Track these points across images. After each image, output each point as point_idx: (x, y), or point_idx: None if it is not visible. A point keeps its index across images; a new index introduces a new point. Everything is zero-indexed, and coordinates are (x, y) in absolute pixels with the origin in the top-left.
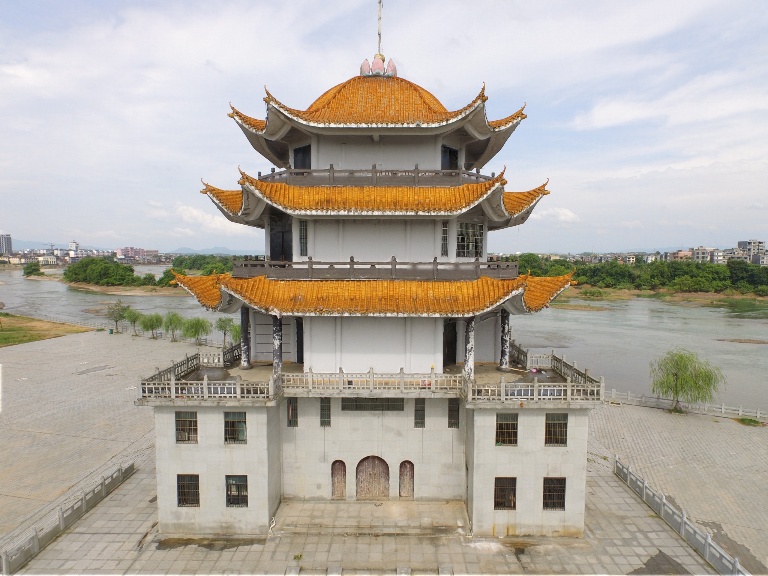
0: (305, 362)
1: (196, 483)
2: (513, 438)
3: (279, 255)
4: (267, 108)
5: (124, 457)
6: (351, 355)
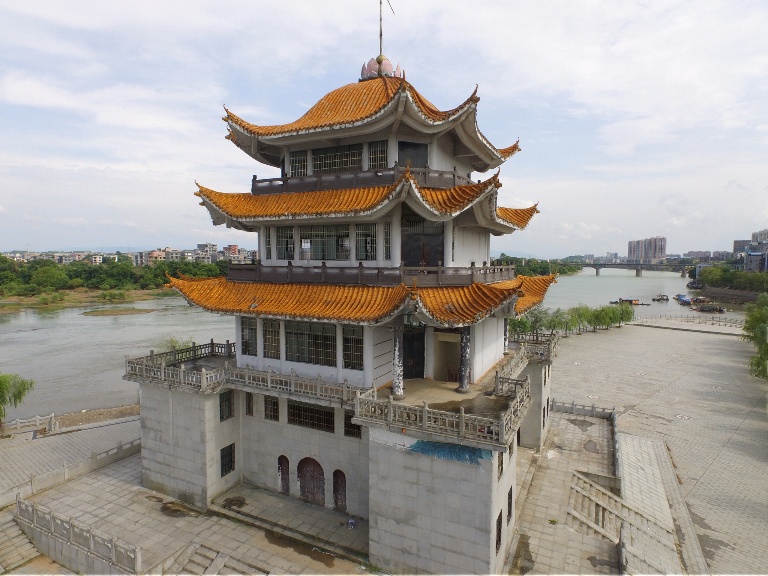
0: (475, 365)
1: (499, 520)
2: (545, 380)
3: (418, 260)
4: (468, 106)
5: None
6: (486, 350)
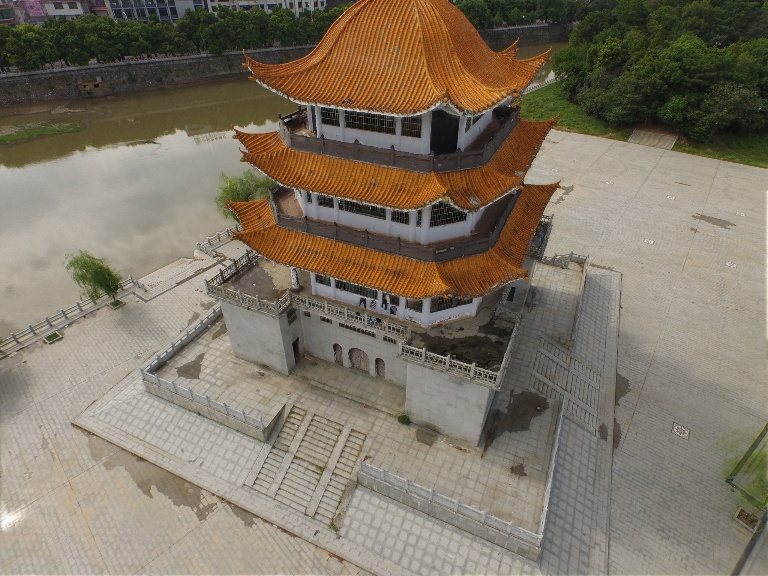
0: None
1: None
2: None
3: None
4: None
5: None
6: None
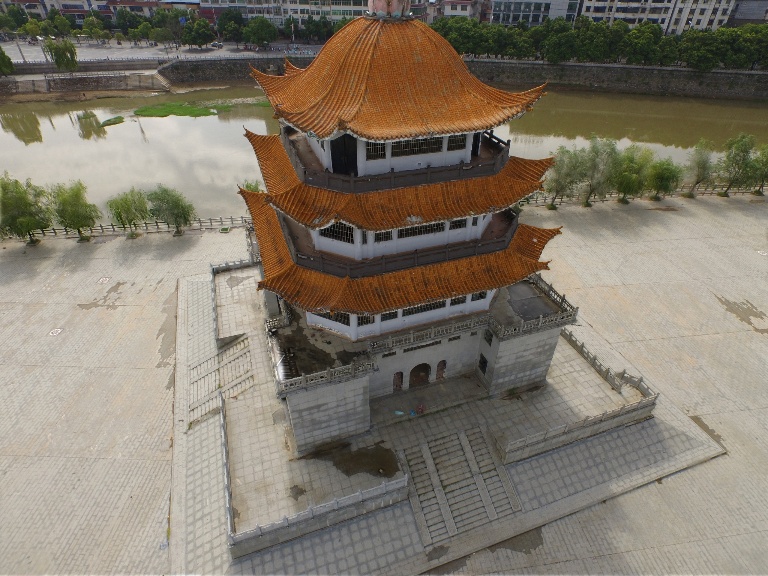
0: None
1: None
2: None
3: None
4: None
5: None
6: None
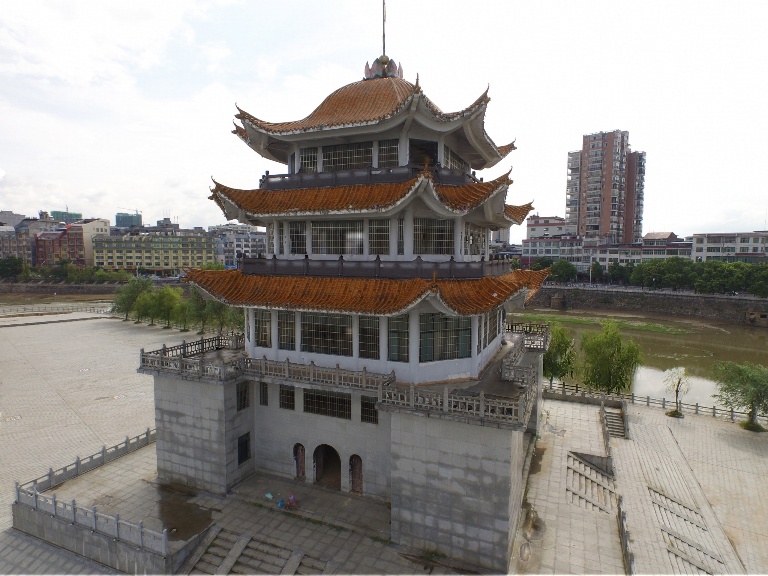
0: None
1: None
2: None
3: None
4: None
5: (724, 574)
6: None
